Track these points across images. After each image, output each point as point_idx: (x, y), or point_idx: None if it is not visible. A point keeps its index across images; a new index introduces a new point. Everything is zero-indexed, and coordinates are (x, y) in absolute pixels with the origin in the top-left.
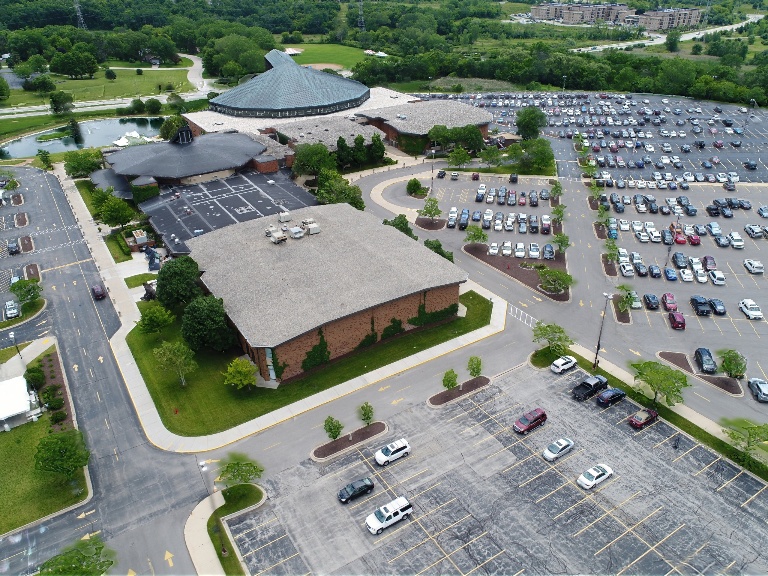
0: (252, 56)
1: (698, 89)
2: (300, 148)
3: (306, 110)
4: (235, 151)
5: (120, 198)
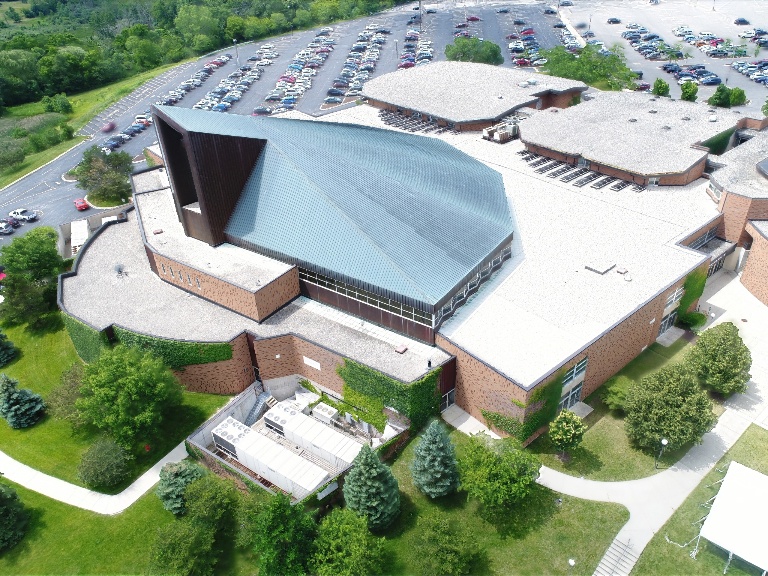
0: None
1: (259, 29)
2: None
3: None
4: None
5: None
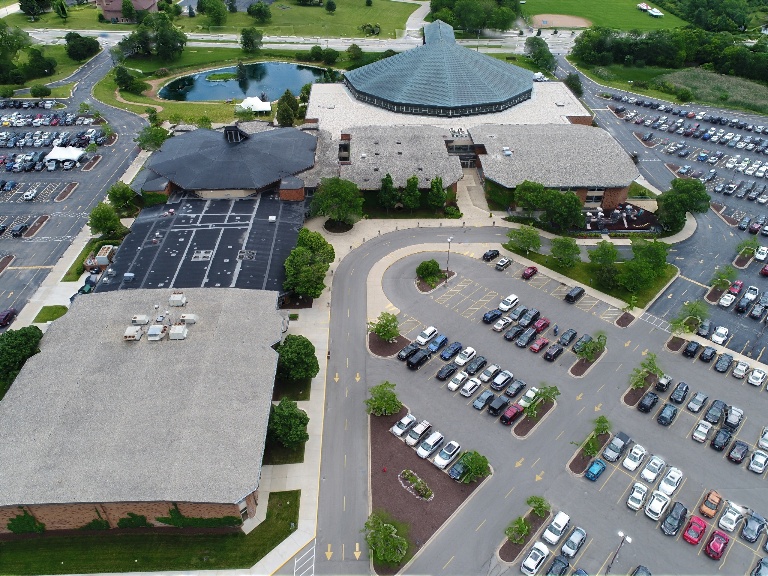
0: (469, 5)
1: None
2: (323, 184)
3: (427, 108)
4: (272, 165)
5: (139, 195)
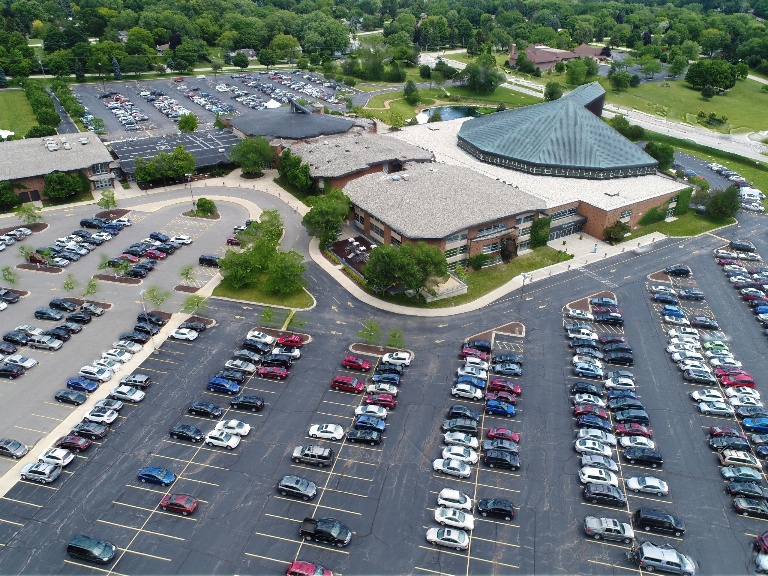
0: None
1: None
2: None
3: None
4: (279, 128)
5: None
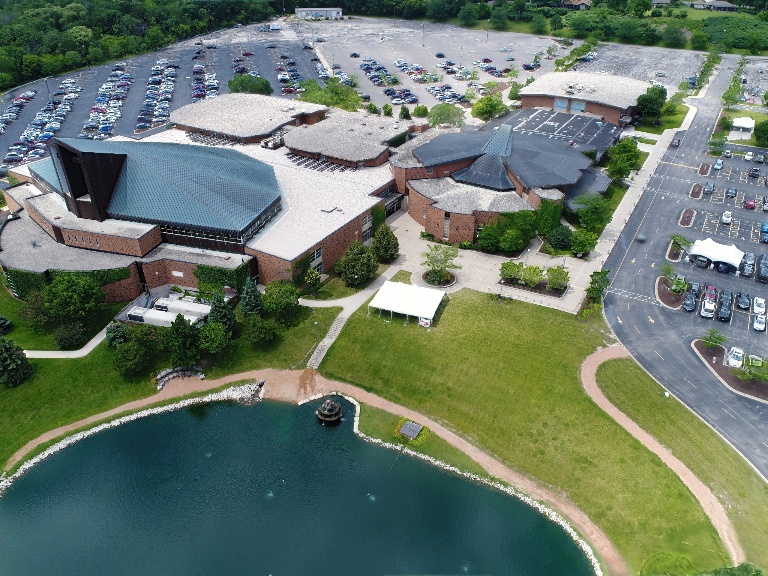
0: None
1: (57, 65)
2: None
3: None
4: None
5: None
